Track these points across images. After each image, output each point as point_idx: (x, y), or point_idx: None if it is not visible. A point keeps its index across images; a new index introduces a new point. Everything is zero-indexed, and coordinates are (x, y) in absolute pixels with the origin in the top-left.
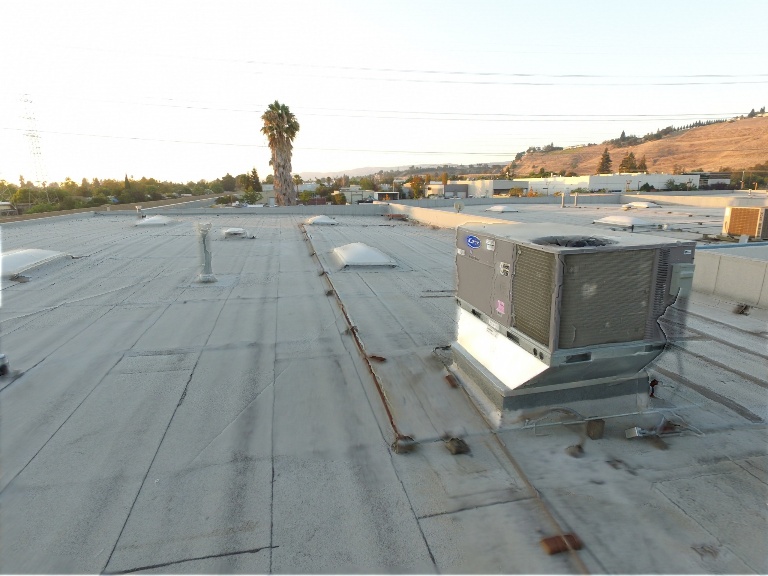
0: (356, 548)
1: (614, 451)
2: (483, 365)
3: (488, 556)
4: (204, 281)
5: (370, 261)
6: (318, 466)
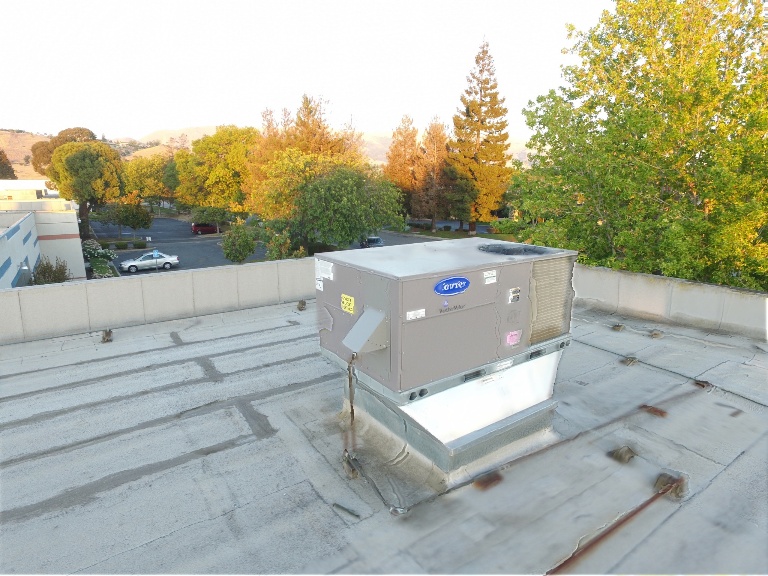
0: None
1: None
2: (513, 414)
3: (702, 434)
4: None
5: None
6: None
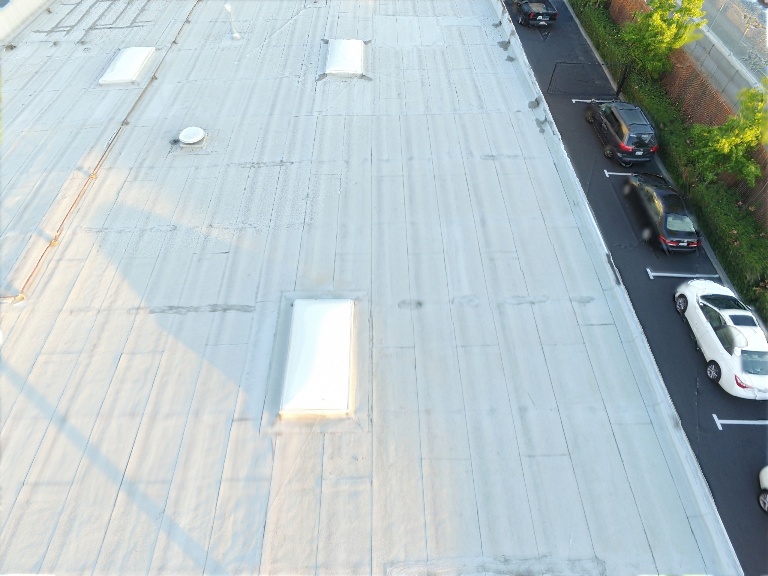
0: None
1: None
2: None
3: None
4: None
5: None
6: None
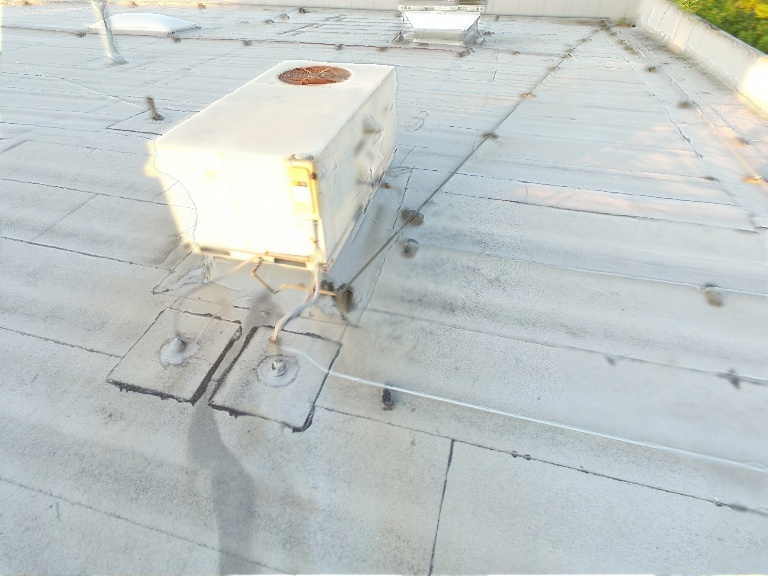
0: (503, 65)
1: None
2: None
3: (515, 58)
4: (122, 62)
5: (182, 26)
6: None
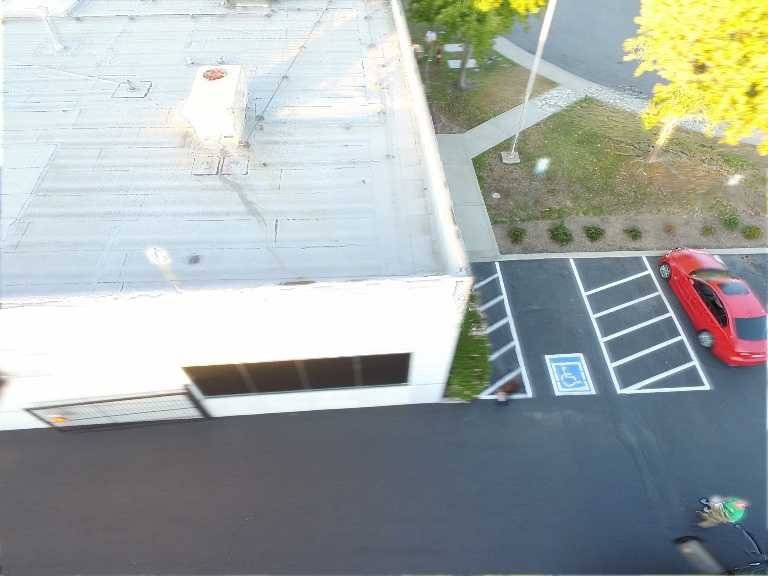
0: None
1: (280, 1)
2: None
3: None
4: (64, 48)
5: (69, 2)
6: (269, 24)
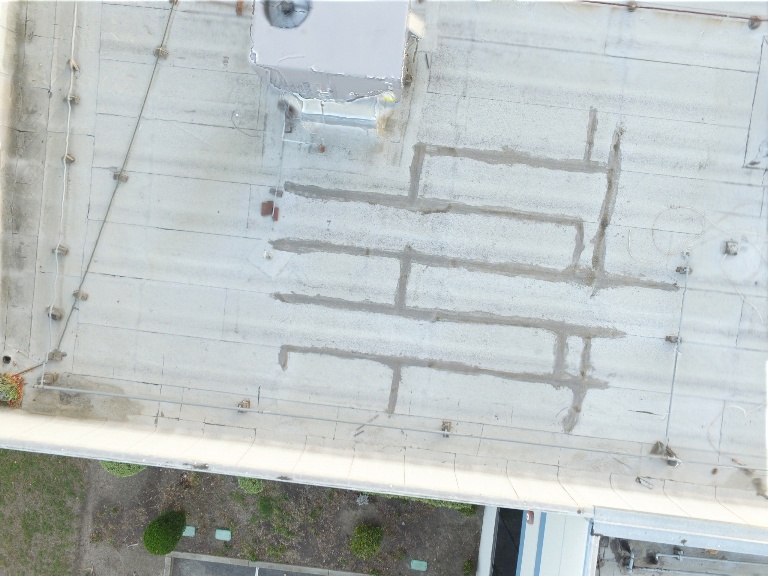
0: None
1: None
2: None
3: None
4: None
5: None
6: None
